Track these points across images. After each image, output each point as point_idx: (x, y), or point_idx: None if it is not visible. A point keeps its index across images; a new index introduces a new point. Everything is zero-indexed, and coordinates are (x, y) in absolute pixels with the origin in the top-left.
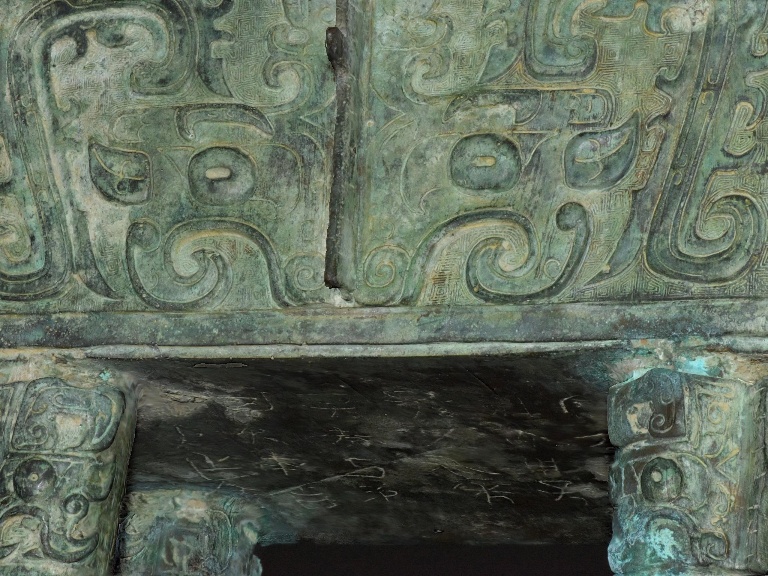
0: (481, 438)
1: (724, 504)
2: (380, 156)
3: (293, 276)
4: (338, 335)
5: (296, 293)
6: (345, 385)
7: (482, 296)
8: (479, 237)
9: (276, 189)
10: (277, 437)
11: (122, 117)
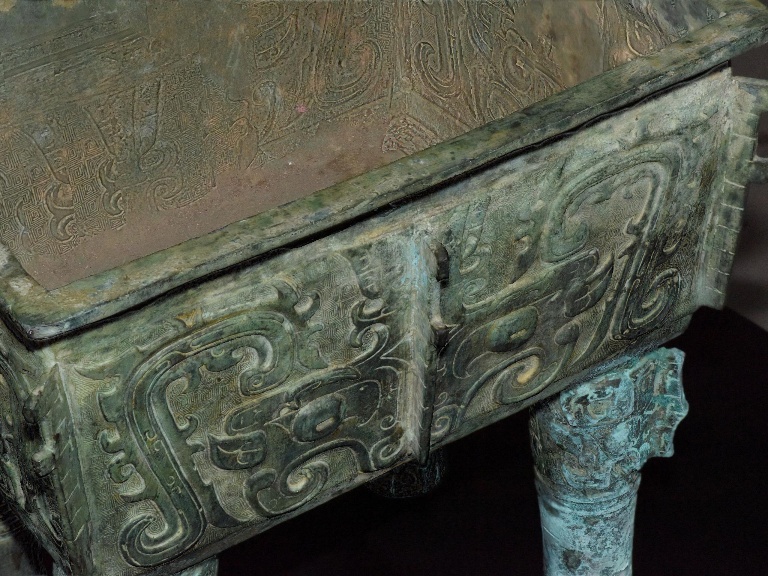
0: None
1: None
2: None
3: None
4: None
5: None
6: None
7: None
8: None
9: None
10: None
11: (272, 3)
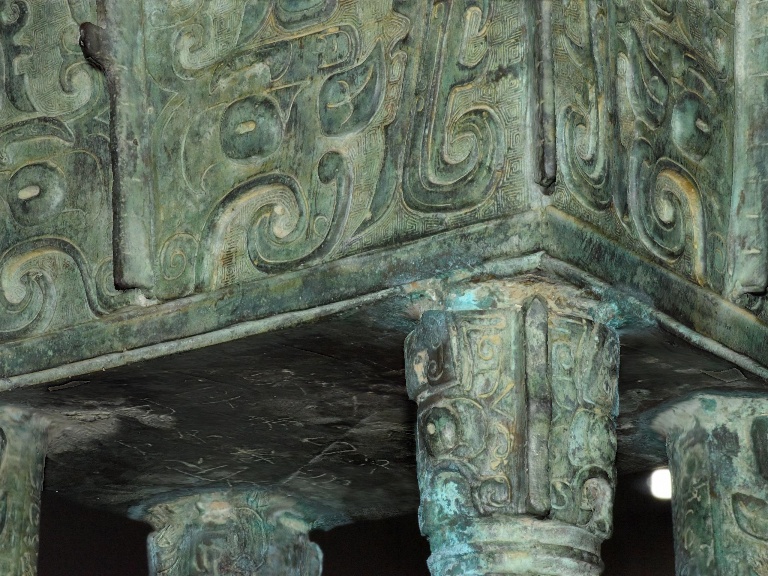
0: (390, 400)
1: (503, 445)
2: (162, 142)
3: (102, 283)
4: (151, 335)
5: (106, 300)
6: (202, 379)
7: (262, 269)
8: (256, 207)
9: (83, 197)
10: (217, 434)
11: None
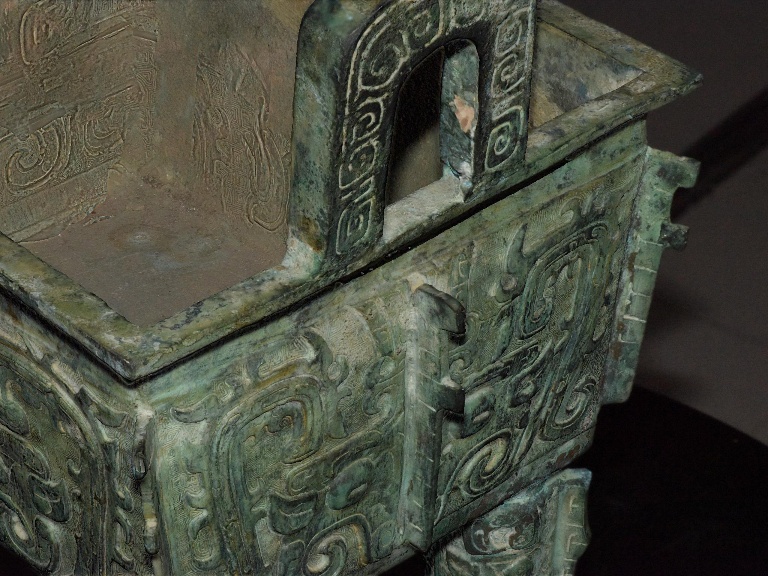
0: None
1: None
2: None
3: None
4: None
5: None
6: None
7: None
8: (1, 501)
9: None
10: None
11: None
